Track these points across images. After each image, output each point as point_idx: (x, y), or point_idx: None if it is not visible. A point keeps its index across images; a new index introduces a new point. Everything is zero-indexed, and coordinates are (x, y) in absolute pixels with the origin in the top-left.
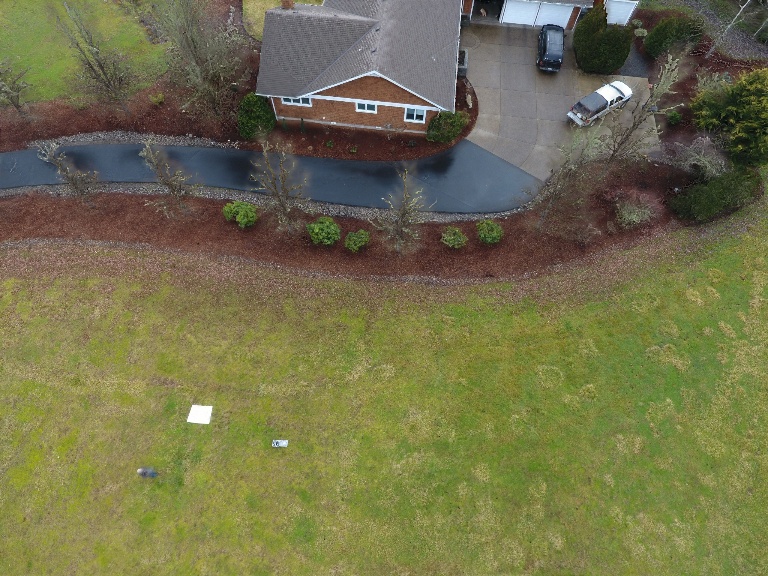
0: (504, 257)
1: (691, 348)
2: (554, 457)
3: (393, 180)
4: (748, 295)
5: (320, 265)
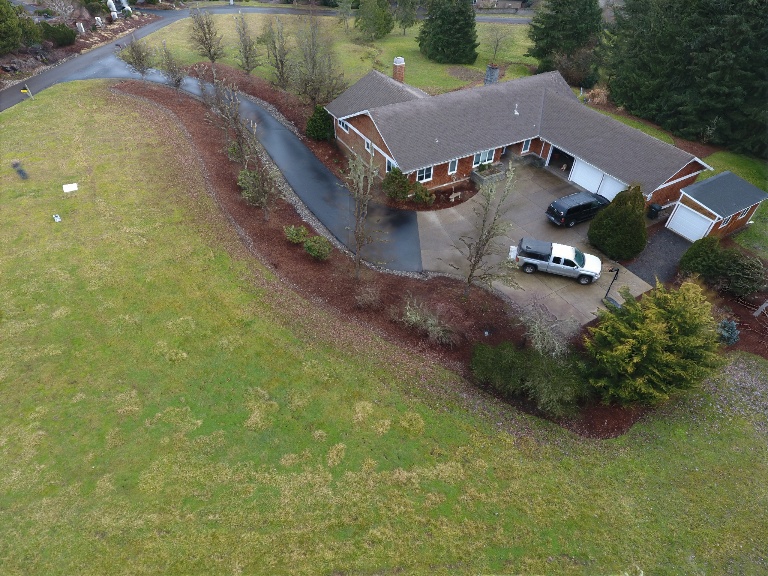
0: (303, 268)
1: (284, 425)
2: (92, 351)
3: (336, 198)
4: (411, 465)
5: (222, 192)
